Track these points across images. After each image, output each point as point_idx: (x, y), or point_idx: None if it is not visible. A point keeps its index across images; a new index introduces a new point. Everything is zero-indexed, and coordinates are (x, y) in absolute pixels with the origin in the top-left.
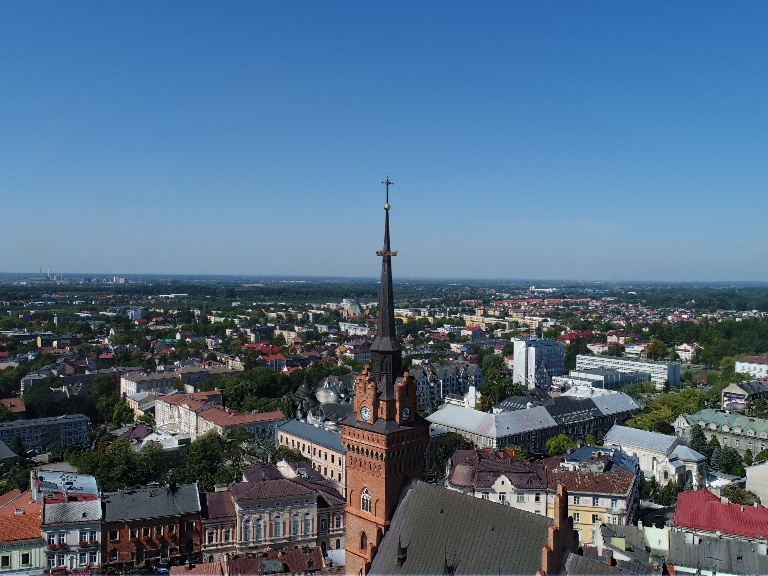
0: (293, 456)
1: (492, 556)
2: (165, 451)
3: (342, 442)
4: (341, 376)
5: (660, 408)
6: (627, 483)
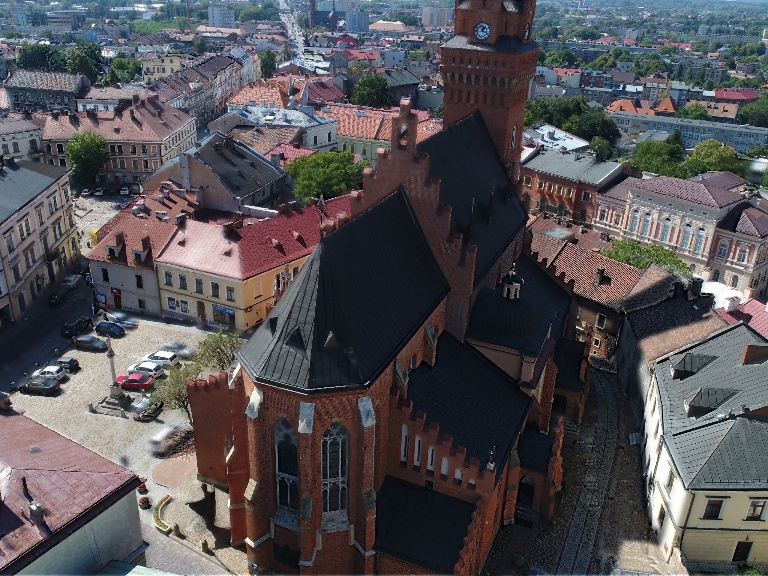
0: None
1: None
2: (738, 161)
3: None
4: None
5: None
6: None
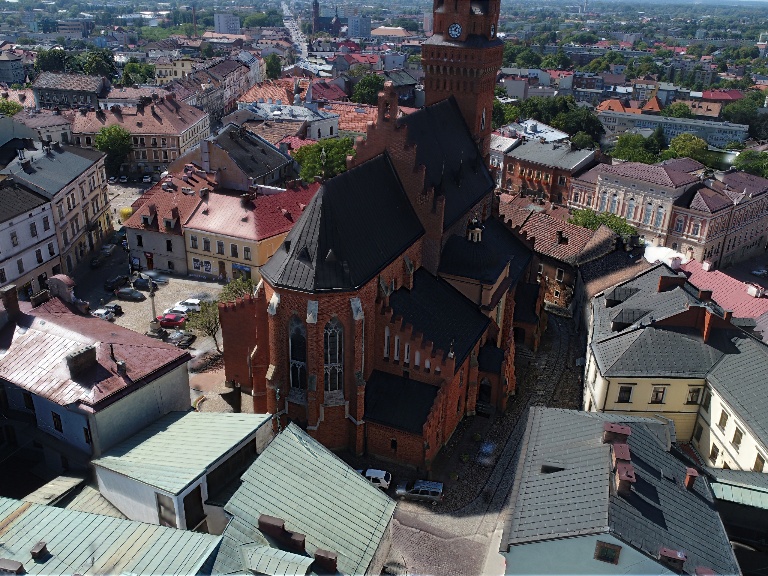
0: None
1: None
2: (708, 152)
3: None
4: None
5: None
6: None
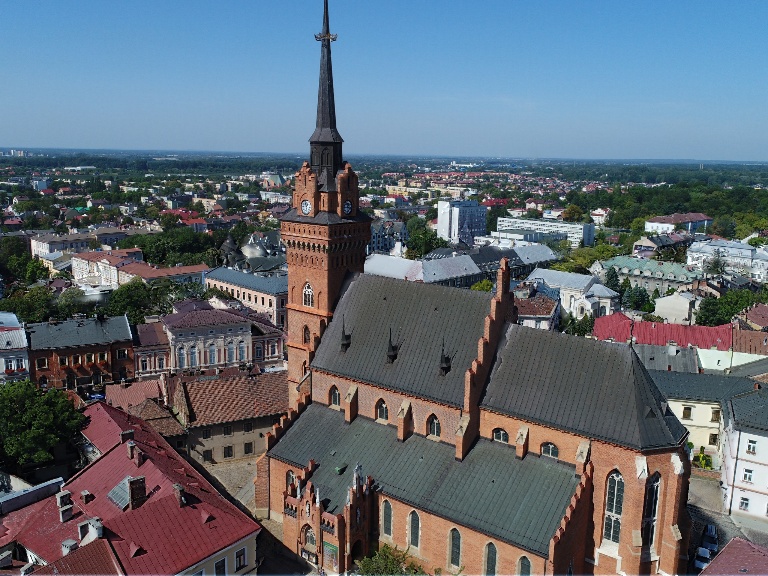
0: (223, 296)
1: (435, 333)
2: (87, 297)
3: (282, 239)
4: (266, 232)
5: (577, 258)
6: (550, 307)
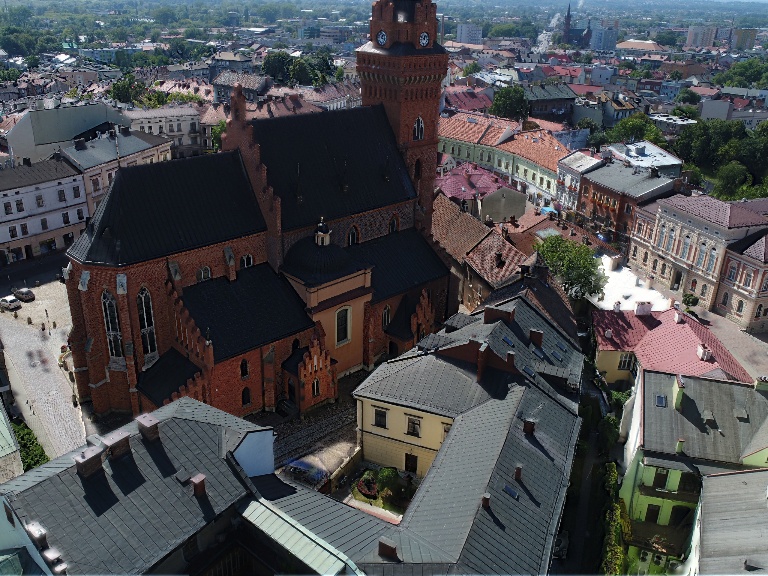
0: None
1: None
2: None
3: None
4: None
5: None
6: None
